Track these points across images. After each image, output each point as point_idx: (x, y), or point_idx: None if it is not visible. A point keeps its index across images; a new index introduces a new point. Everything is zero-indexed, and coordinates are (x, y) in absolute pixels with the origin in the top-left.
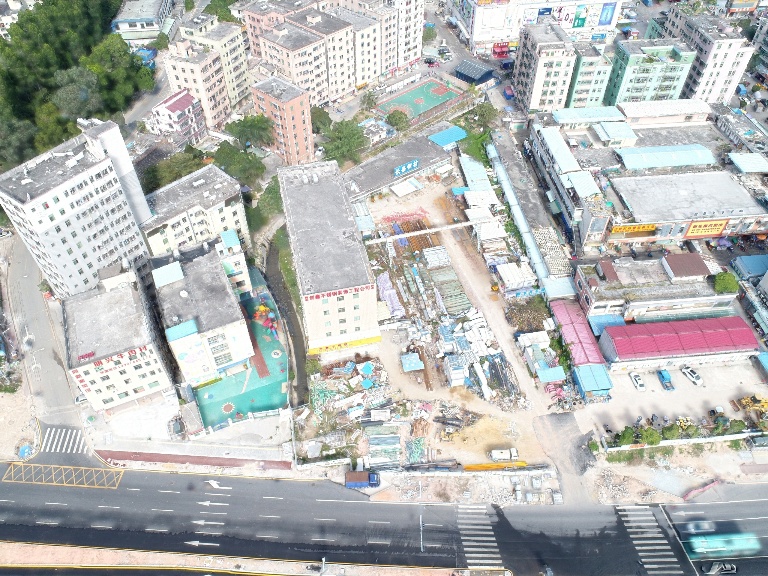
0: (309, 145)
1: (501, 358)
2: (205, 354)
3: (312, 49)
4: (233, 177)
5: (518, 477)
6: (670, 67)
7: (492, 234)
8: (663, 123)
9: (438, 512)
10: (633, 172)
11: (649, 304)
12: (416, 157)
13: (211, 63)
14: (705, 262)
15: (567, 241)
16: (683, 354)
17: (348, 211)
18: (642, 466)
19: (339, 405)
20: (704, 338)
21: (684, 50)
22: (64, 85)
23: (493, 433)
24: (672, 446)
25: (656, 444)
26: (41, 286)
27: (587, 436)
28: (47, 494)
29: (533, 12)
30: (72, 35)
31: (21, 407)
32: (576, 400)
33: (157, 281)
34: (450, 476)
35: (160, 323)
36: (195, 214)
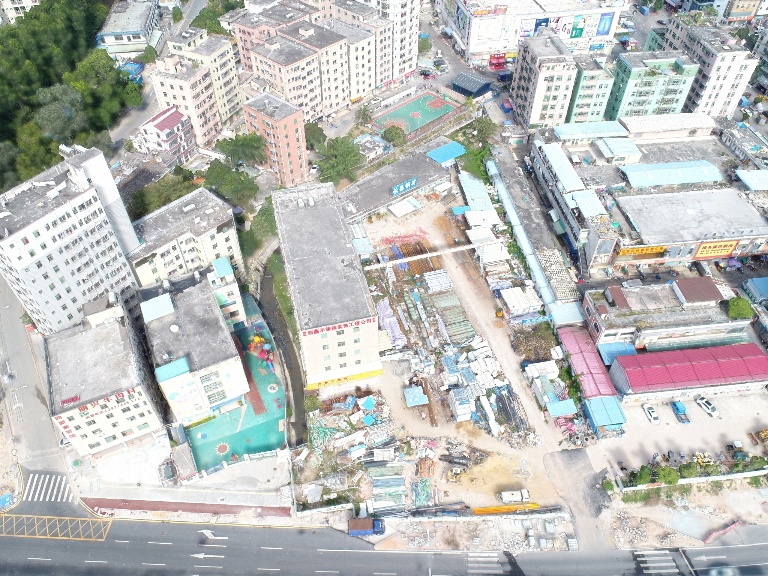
0: (303, 163)
1: (508, 390)
2: (197, 393)
3: (305, 64)
4: (225, 197)
5: (530, 521)
6: (673, 80)
7: (495, 256)
8: (667, 138)
9: (447, 561)
10: (638, 190)
11: (661, 332)
12: (414, 175)
13: (201, 79)
14: (717, 286)
15: (572, 263)
16: (698, 385)
17: (346, 237)
18: (659, 506)
19: (340, 444)
20: (719, 368)
21: (687, 63)
22: (47, 103)
23: (502, 472)
24: (690, 484)
25: (674, 484)
26: (23, 318)
27: (601, 474)
28: (29, 548)
29: (530, 23)
30: (55, 50)
31: (2, 451)
32: (588, 435)
33: (146, 315)
34: (459, 521)
35: (149, 357)
36: (185, 241)
